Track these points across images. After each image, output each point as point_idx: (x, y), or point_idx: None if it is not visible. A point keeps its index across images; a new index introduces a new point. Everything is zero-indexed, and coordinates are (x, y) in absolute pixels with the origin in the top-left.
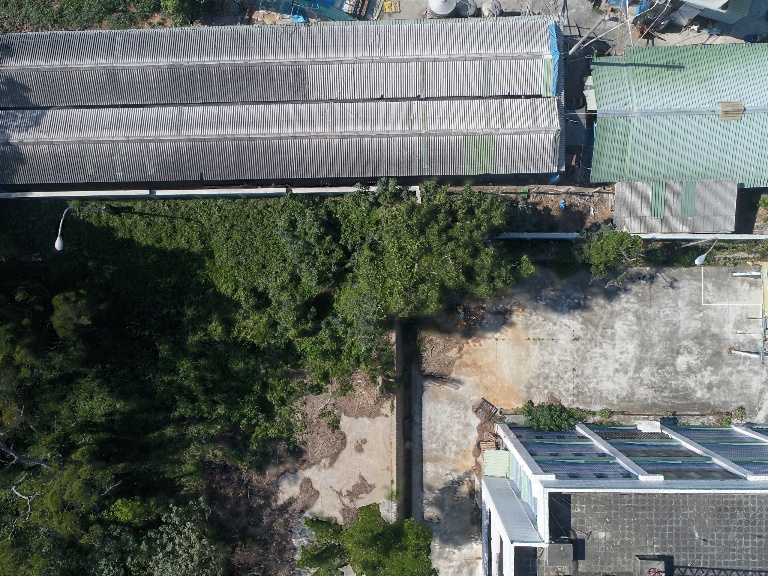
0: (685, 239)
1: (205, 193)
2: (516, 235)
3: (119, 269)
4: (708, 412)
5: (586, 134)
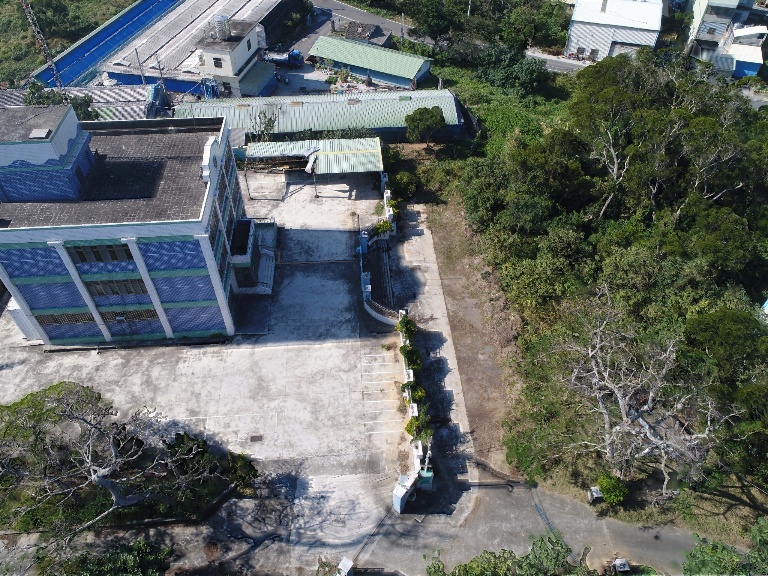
0: None
1: None
2: None
3: None
4: None
5: None
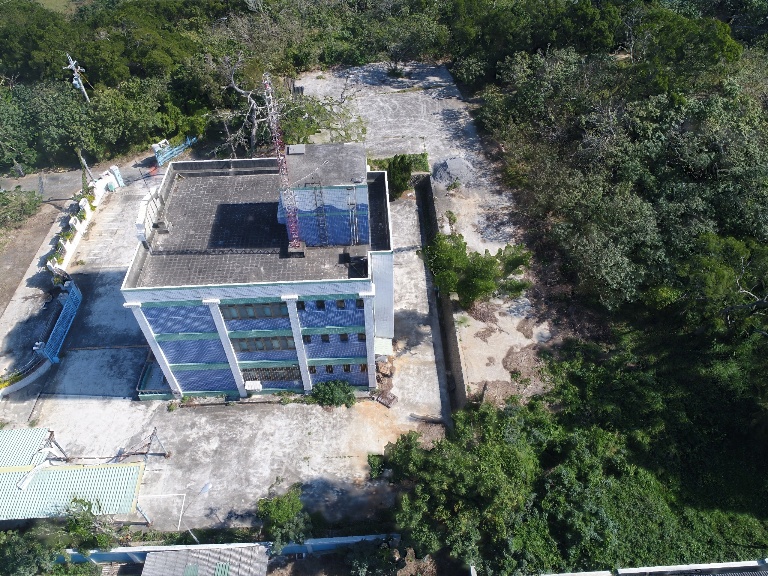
0: None
1: (704, 565)
2: (369, 537)
3: (759, 489)
4: (198, 407)
5: None
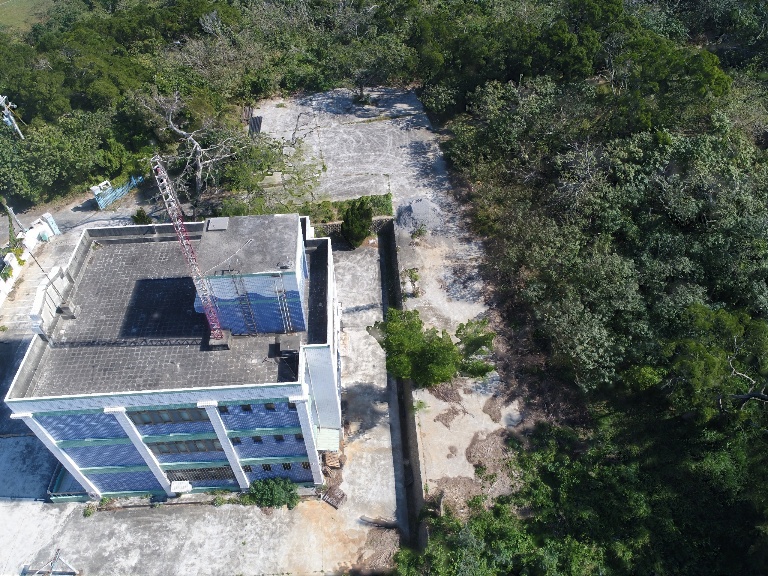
0: None
1: None
2: None
3: None
4: (119, 510)
5: None
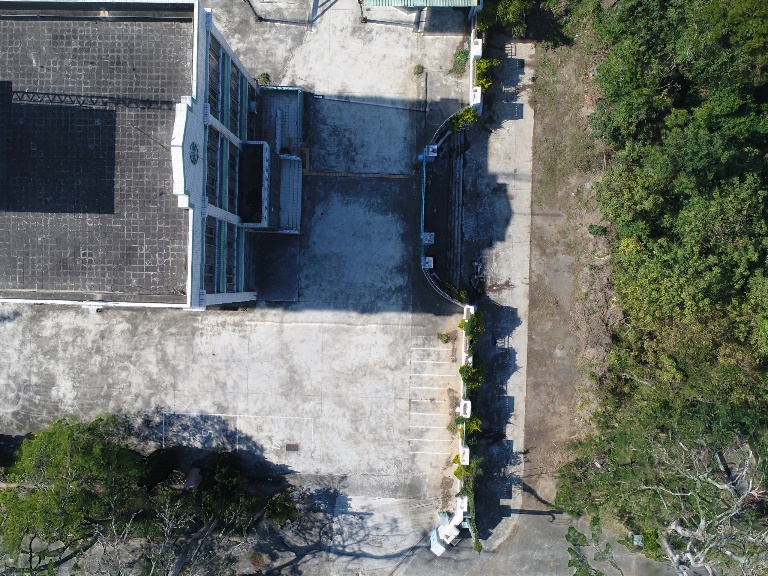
0: None
1: None
2: None
3: None
4: None
5: None
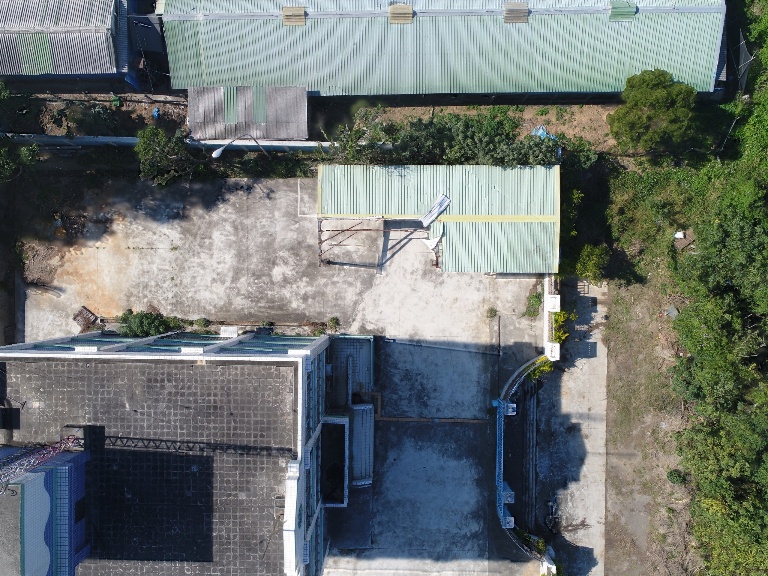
0: (277, 149)
1: None
2: (91, 138)
3: None
4: (304, 323)
5: (161, 39)
